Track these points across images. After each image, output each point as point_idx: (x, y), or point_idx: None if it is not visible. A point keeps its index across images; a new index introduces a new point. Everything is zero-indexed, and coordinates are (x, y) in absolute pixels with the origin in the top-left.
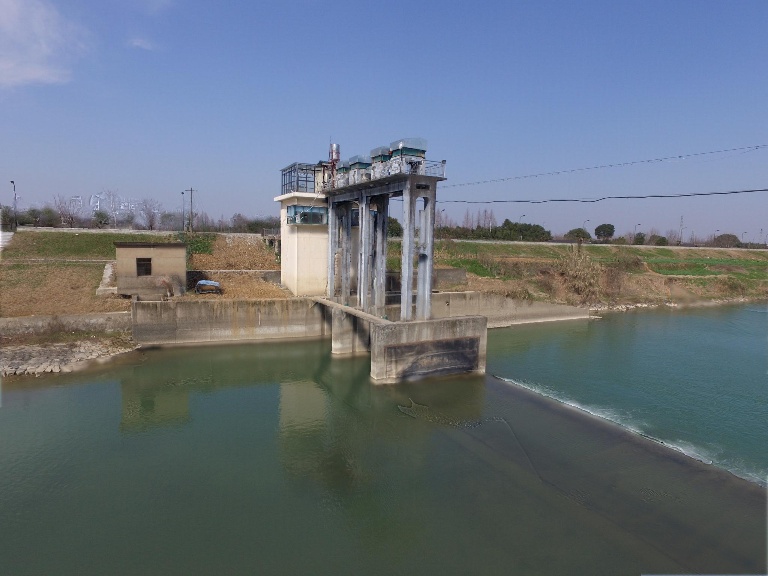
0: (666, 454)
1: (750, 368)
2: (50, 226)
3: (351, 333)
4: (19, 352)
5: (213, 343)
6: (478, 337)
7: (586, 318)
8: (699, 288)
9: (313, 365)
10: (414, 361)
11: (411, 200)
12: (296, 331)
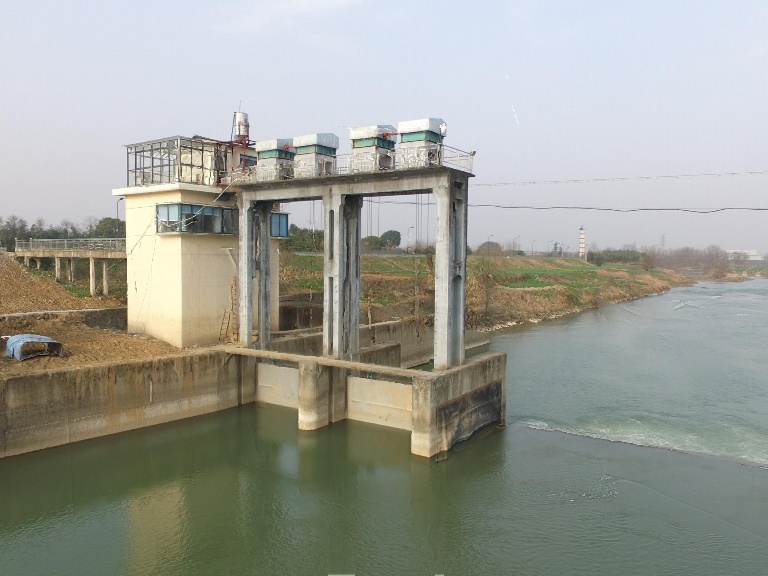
0: None
1: (698, 380)
2: None
3: (327, 396)
4: None
5: (75, 446)
6: (501, 380)
7: (488, 343)
8: (547, 301)
9: (228, 455)
10: (459, 423)
11: (450, 203)
12: (205, 404)
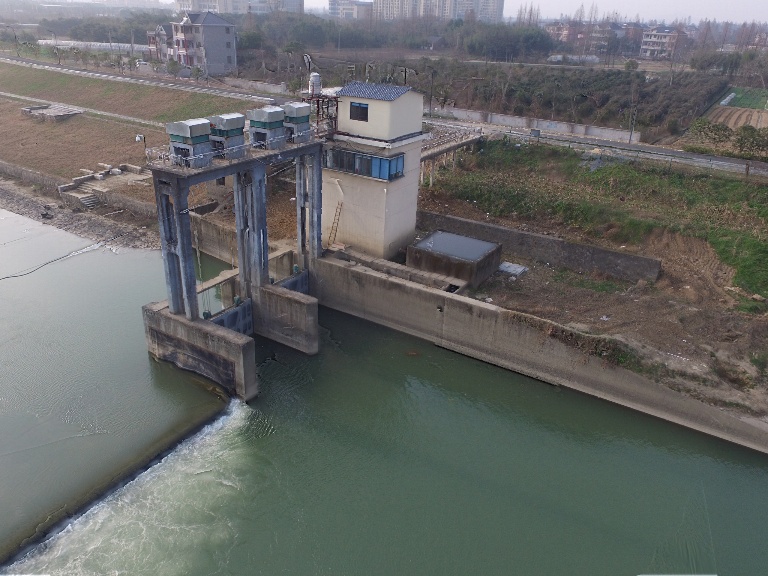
0: (15, 534)
1: None
2: None
3: (232, 300)
4: (121, 230)
5: (221, 261)
6: (233, 362)
7: None
8: None
9: None
10: (173, 352)
11: (157, 196)
12: (270, 276)
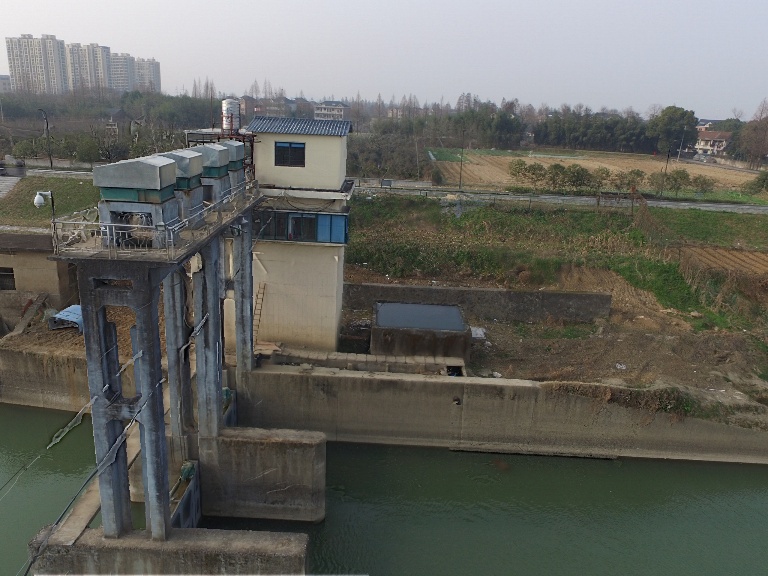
0: None
1: None
2: (90, 161)
3: None
4: None
5: (47, 411)
6: None
7: None
8: None
9: None
10: None
11: (85, 312)
12: None
